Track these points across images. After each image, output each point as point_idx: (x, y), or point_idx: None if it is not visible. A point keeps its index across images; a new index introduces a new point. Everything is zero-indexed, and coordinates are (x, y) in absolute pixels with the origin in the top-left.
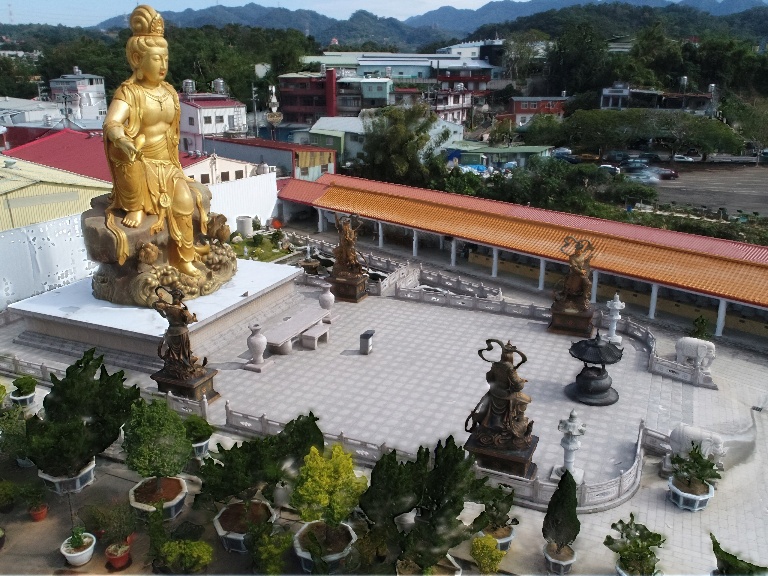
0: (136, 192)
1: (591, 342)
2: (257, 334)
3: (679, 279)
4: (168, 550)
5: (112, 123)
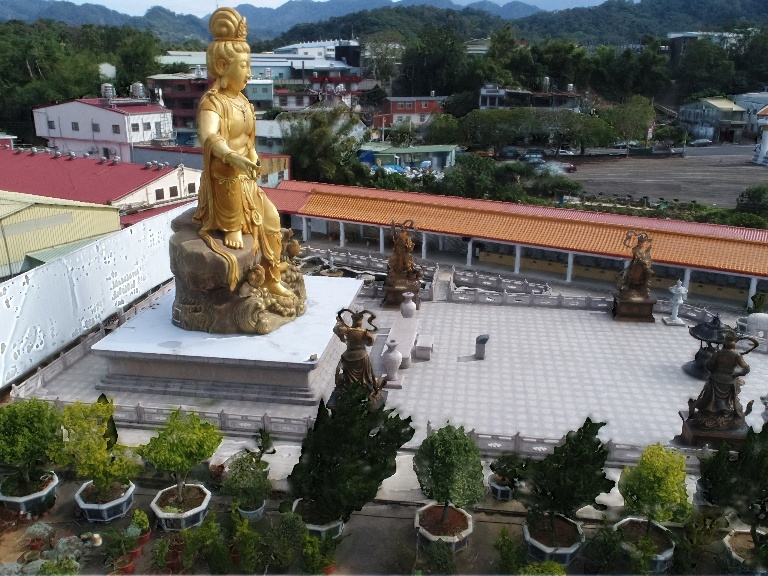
0: (237, 211)
1: (713, 325)
2: (395, 350)
3: (714, 262)
4: (528, 575)
5: (215, 136)
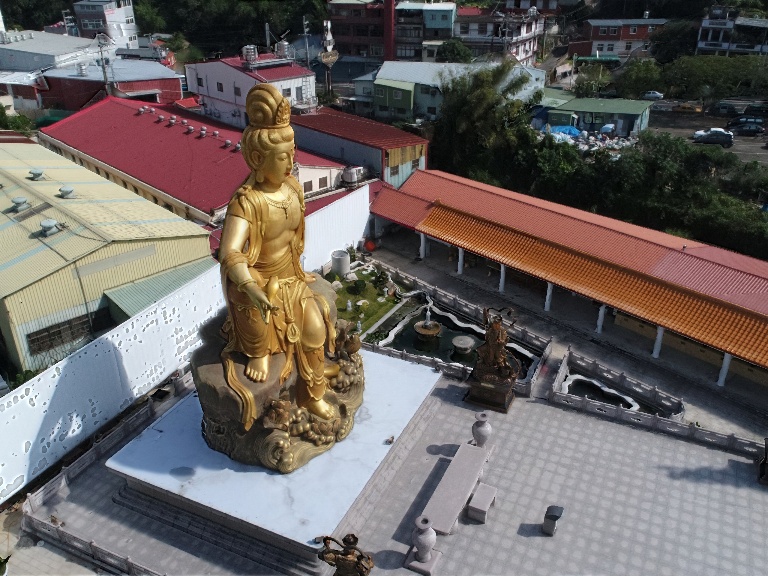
0: (262, 336)
1: None
2: (426, 532)
3: None
4: None
5: (233, 258)
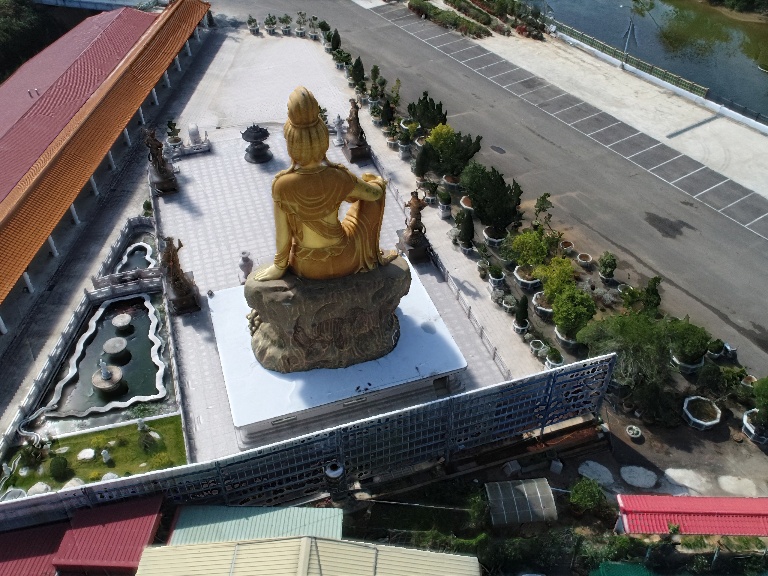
0: None
1: (258, 130)
2: None
3: (116, 129)
4: None
5: None
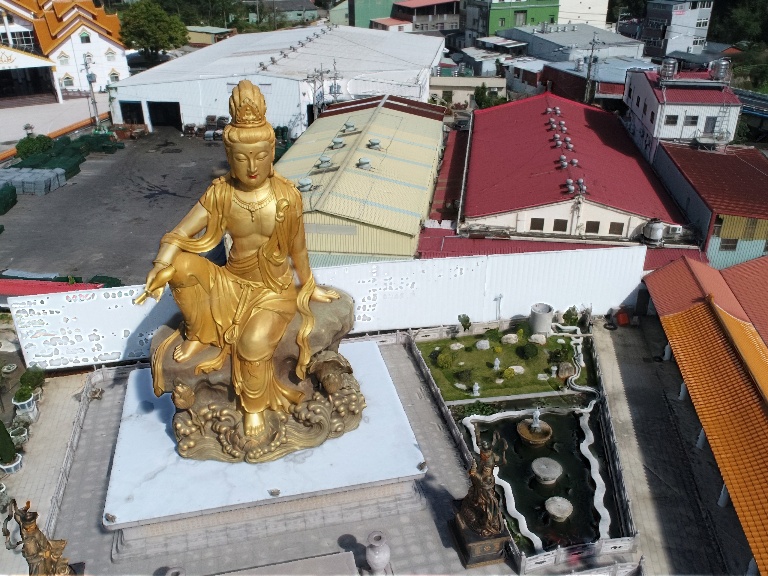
0: (190, 320)
1: None
2: None
3: None
4: None
5: (166, 237)
